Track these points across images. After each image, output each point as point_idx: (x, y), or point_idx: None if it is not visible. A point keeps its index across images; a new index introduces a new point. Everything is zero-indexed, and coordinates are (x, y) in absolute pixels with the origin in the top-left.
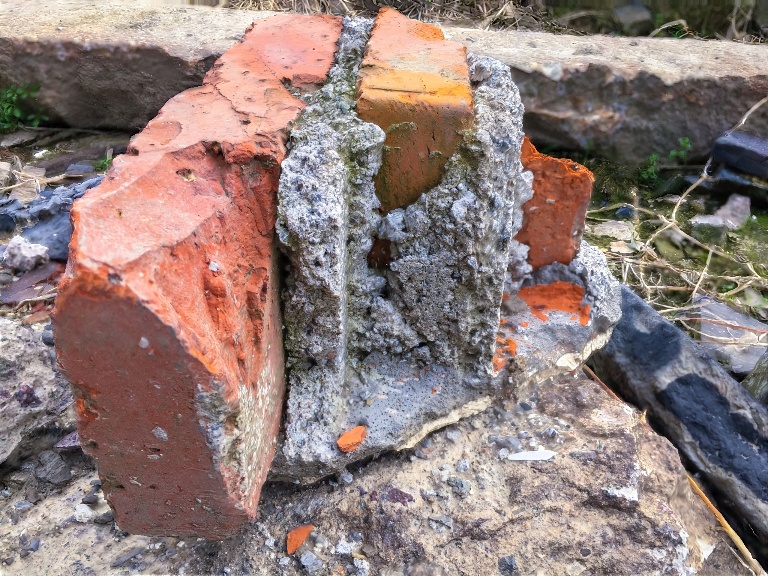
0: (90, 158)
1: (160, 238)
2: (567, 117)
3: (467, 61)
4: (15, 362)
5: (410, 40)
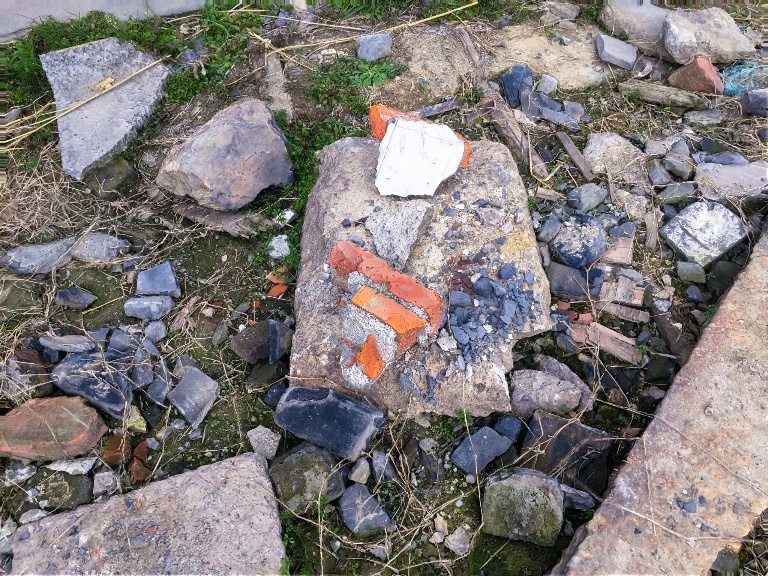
0: (670, 347)
1: (343, 251)
2: (552, 572)
3: (379, 319)
4: (398, 261)
5: (393, 310)
